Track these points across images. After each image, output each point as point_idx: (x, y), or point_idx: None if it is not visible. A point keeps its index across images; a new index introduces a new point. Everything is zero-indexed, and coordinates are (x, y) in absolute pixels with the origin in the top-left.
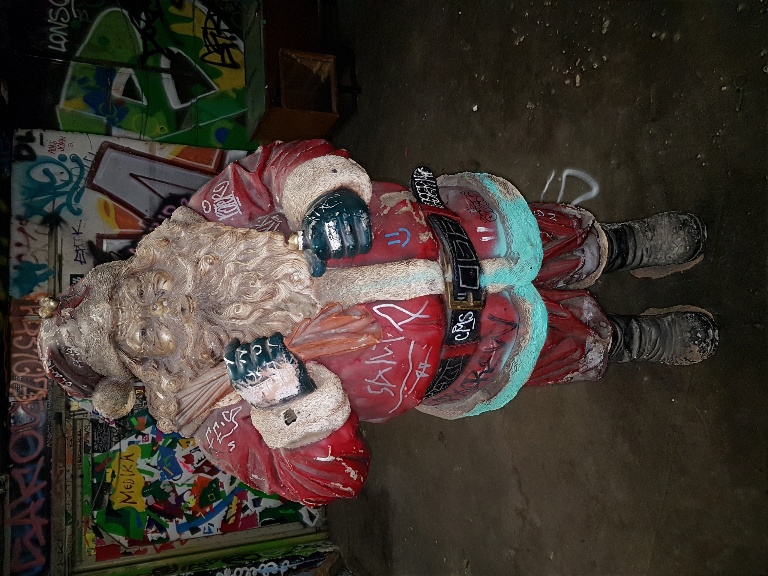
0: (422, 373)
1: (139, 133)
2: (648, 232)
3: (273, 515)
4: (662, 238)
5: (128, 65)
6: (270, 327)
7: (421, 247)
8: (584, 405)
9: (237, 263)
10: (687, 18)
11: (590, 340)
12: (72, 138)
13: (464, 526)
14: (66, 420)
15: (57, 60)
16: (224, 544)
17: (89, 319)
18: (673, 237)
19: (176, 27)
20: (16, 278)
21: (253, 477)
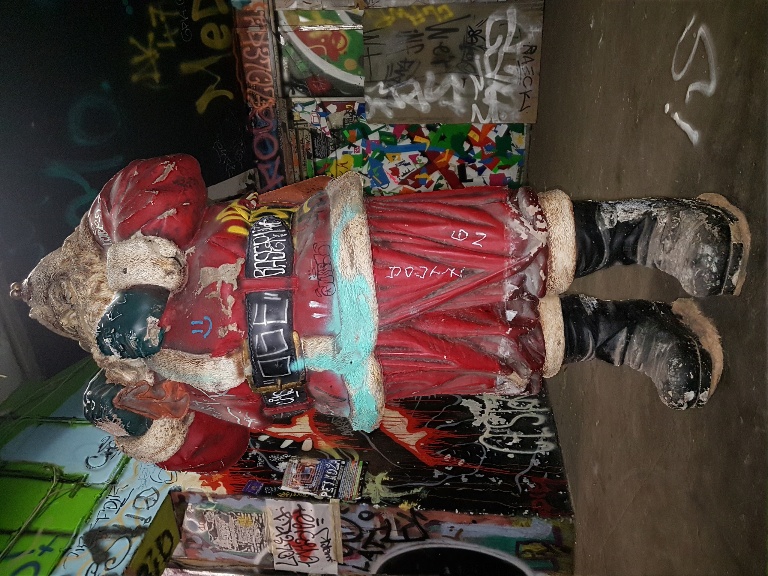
0: (251, 421)
1: None
2: (668, 240)
3: None
4: (678, 259)
5: None
6: None
7: (219, 342)
8: None
9: None
10: None
11: (503, 377)
12: None
13: None
14: (290, 130)
15: None
16: None
17: None
18: (683, 270)
19: None
20: None
21: None
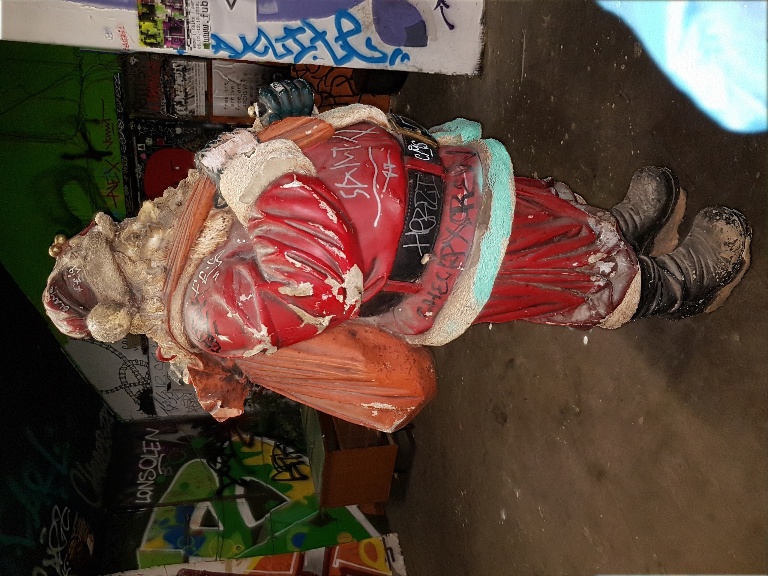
0: (390, 174)
1: (215, 555)
2: (624, 201)
3: None
4: (636, 193)
5: (205, 499)
6: None
7: None
8: (718, 444)
9: None
10: (570, 110)
11: (593, 222)
12: (149, 573)
13: None
14: None
15: (142, 509)
16: None
17: (91, 233)
18: (641, 182)
19: (247, 461)
20: None
21: (241, 301)
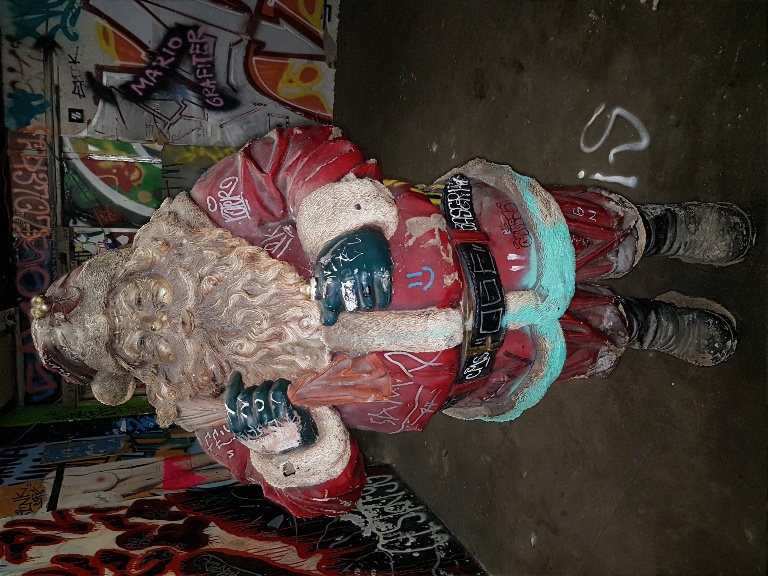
0: (427, 410)
1: None
2: (692, 225)
3: None
4: (706, 235)
5: None
6: (274, 370)
7: (444, 292)
8: None
9: (243, 296)
10: None
11: (604, 349)
12: None
13: (448, 421)
14: (71, 261)
15: None
16: None
17: (84, 328)
18: (718, 239)
19: None
20: (11, 108)
21: (250, 479)
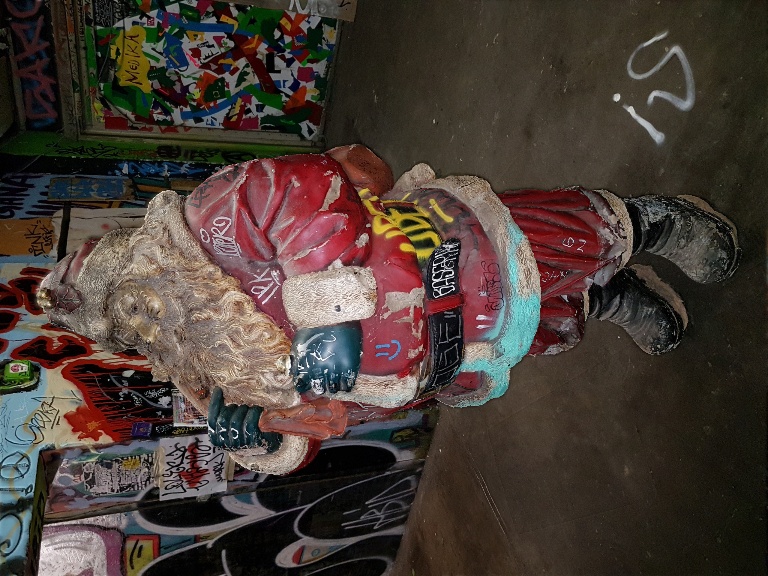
0: None
1: None
2: (684, 239)
3: (274, 122)
4: (691, 255)
5: None
6: (250, 398)
7: (406, 363)
8: None
9: None
10: None
11: None
12: None
13: None
14: None
15: None
16: (225, 138)
17: (87, 325)
18: (699, 265)
19: None
20: None
21: None
